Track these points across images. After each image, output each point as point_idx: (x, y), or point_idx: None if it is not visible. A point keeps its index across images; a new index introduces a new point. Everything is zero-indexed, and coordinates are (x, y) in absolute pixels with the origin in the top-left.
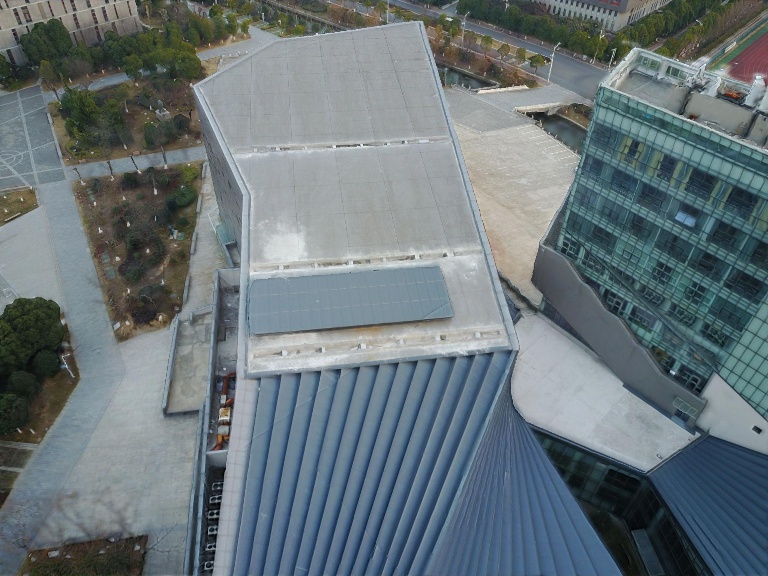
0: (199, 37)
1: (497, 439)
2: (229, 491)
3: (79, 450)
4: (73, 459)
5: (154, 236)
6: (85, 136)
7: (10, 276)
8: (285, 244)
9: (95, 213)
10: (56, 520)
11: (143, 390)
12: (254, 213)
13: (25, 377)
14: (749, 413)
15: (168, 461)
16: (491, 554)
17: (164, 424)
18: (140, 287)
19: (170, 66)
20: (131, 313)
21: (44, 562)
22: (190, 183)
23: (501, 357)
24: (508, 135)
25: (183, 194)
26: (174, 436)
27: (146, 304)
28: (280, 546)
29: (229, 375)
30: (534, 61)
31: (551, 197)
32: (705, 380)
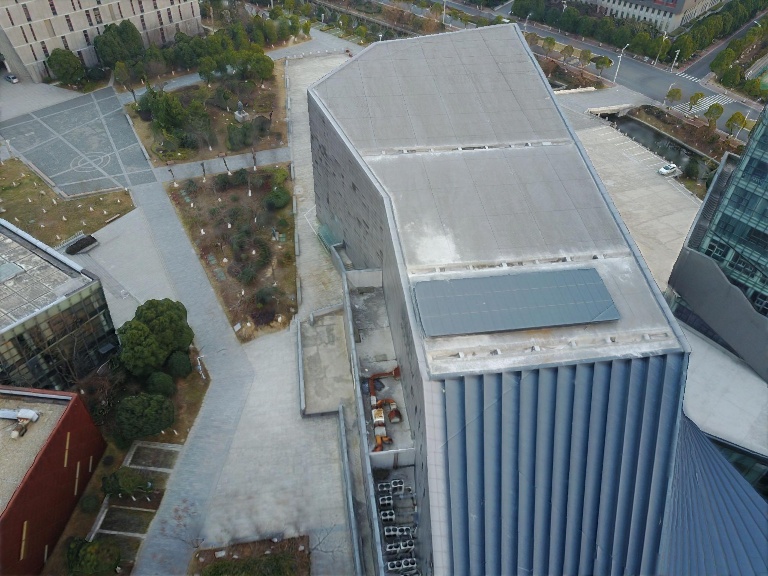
0: (264, 38)
1: (683, 440)
2: (435, 492)
3: (224, 451)
4: (220, 460)
5: (258, 237)
6: (174, 138)
7: (121, 277)
8: (436, 246)
9: (193, 214)
10: (215, 520)
11: (276, 391)
12: (398, 215)
13: (165, 378)
14: None
15: (314, 462)
16: (705, 555)
17: (303, 425)
18: (253, 288)
19: (243, 67)
20: (250, 314)
21: (213, 562)
22: (282, 184)
23: (674, 359)
24: (586, 136)
25: (278, 195)
26: (315, 437)
27: (264, 305)
28: (496, 547)
29: (373, 376)
30: (600, 62)
31: (640, 199)
32: None
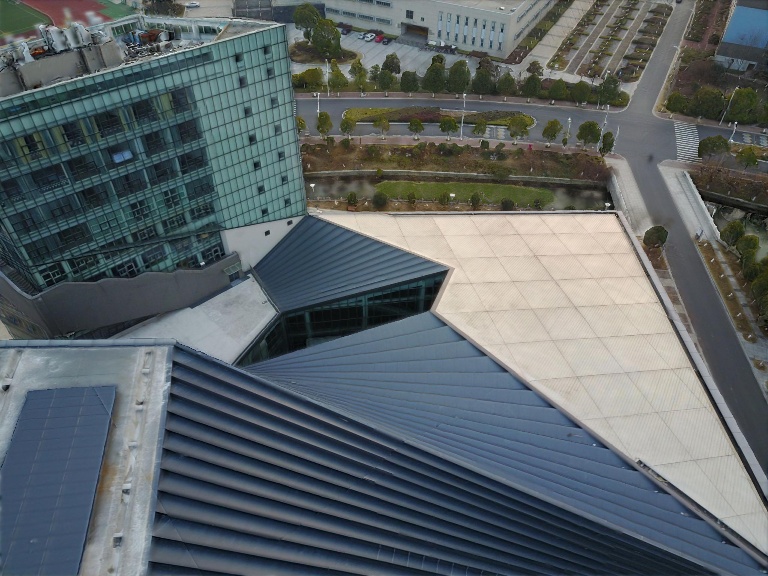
0: None
1: None
2: None
3: None
4: None
5: None
6: None
7: None
8: None
9: None
10: None
11: None
12: None
13: None
14: (257, 229)
15: None
16: None
17: None
18: None
19: None
20: None
21: None
22: None
23: (179, 357)
24: None
25: None
26: None
27: None
28: None
29: None
30: None
31: None
32: (220, 244)
